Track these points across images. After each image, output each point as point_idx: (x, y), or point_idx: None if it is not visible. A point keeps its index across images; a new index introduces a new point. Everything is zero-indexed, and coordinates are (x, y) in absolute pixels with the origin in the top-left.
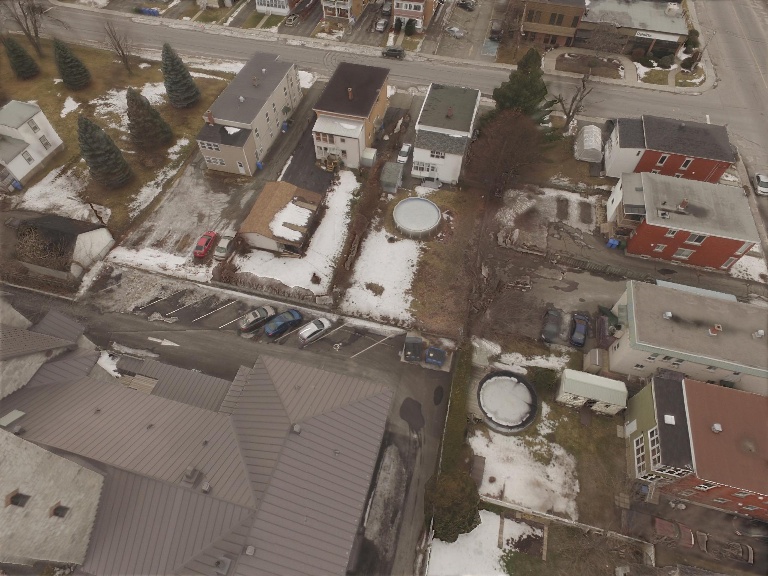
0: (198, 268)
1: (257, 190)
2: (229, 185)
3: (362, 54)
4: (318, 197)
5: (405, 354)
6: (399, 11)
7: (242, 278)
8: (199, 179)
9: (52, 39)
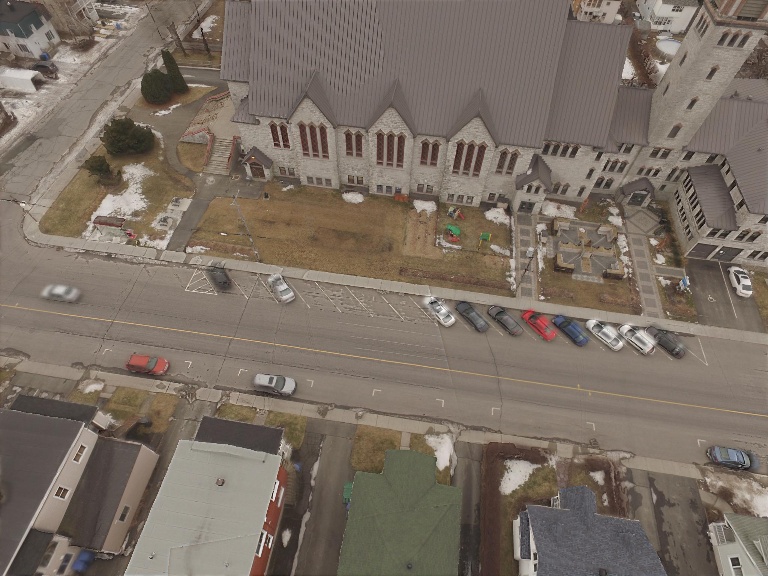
0: None
1: None
2: None
3: None
4: None
5: None
6: None
7: None
8: None
9: None
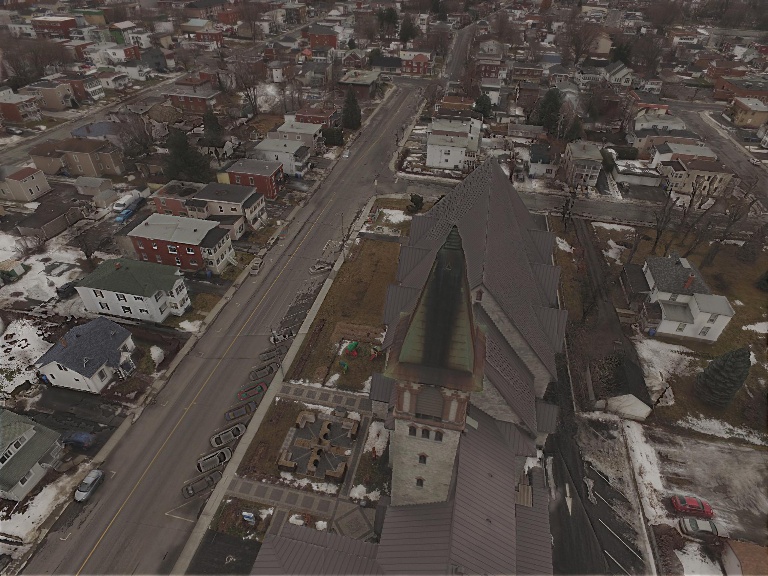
0: (659, 506)
1: None
2: None
3: None
4: None
5: None
6: None
7: (672, 561)
8: None
9: None
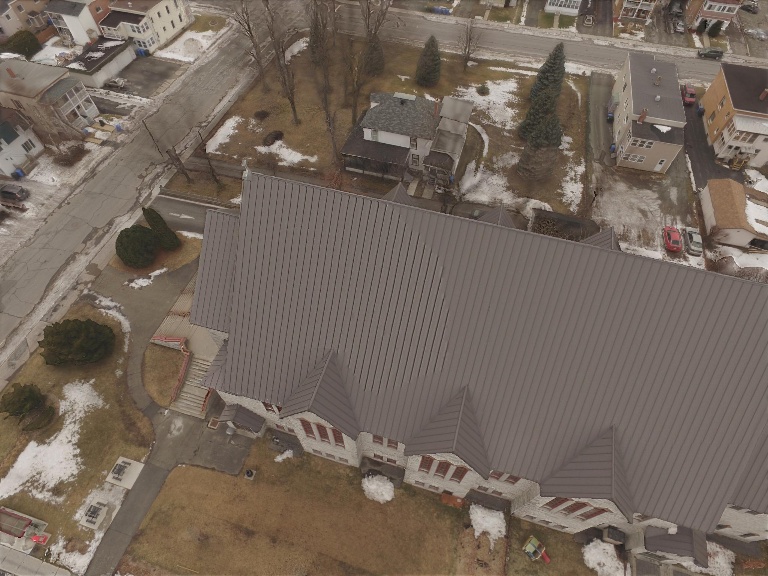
0: (679, 262)
1: (679, 187)
2: (648, 182)
3: (677, 55)
4: (764, 195)
5: None
6: (709, 13)
7: (757, 272)
8: (614, 175)
9: (364, 36)
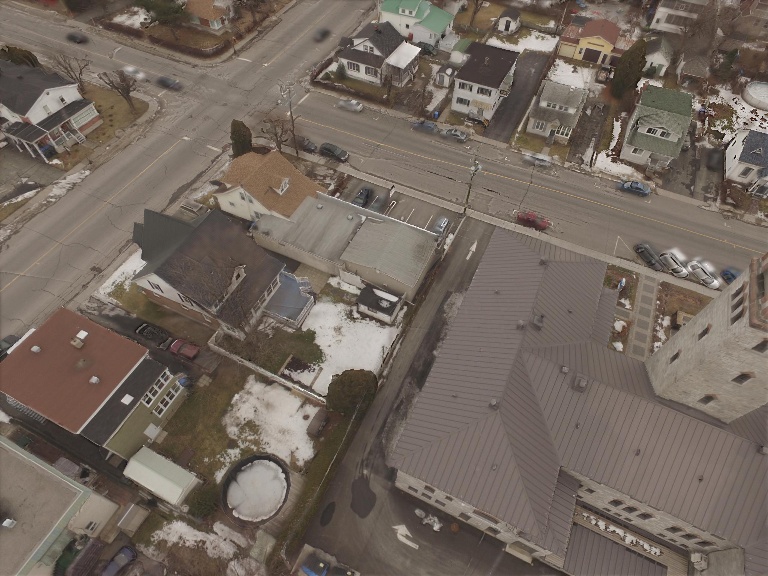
0: None
1: None
2: None
3: None
4: None
5: (354, 574)
6: None
7: None
8: None
9: None
